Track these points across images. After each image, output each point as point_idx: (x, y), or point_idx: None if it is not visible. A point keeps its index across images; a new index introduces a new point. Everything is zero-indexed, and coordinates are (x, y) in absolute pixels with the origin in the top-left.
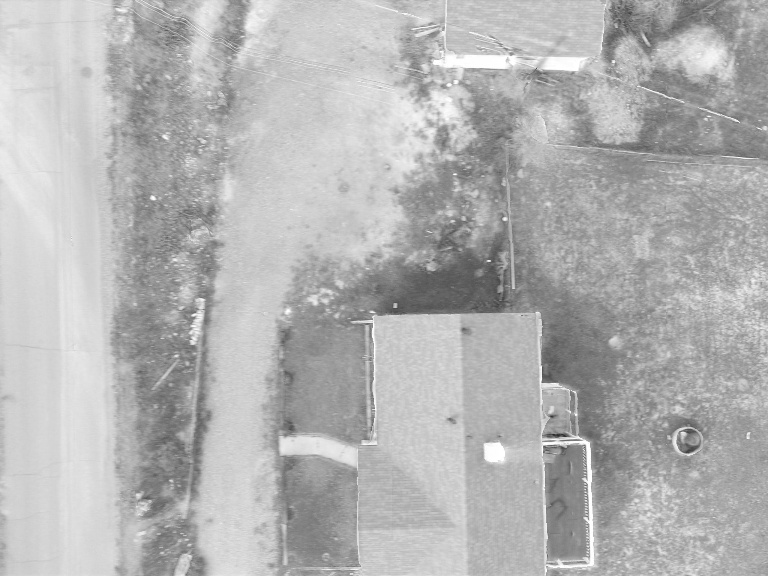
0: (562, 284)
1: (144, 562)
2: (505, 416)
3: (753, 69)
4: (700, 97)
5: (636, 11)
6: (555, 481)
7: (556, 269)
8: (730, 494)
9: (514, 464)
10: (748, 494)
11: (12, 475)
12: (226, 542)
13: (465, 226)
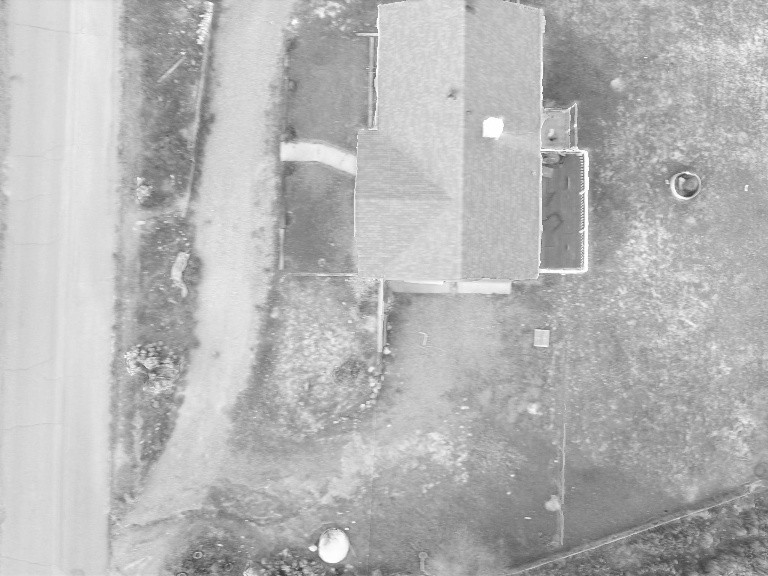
0: (566, 22)
1: (142, 252)
2: (505, 101)
3: None
4: None
5: None
6: (552, 195)
7: (561, 7)
8: (726, 244)
9: (512, 150)
10: (744, 246)
11: (16, 156)
12: (224, 244)
13: None
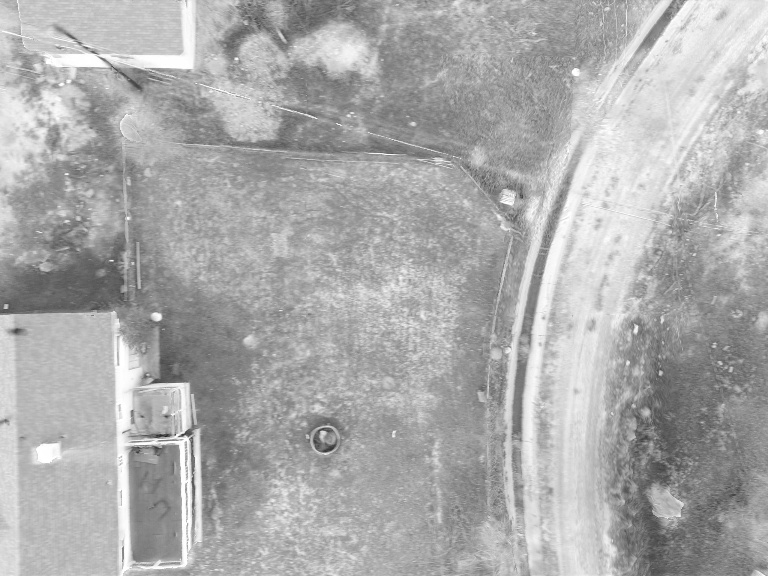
0: (194, 283)
1: None
2: (70, 417)
3: (399, 65)
4: (343, 94)
5: (270, 8)
6: (158, 482)
7: (187, 268)
8: (374, 493)
9: (81, 465)
10: (394, 493)
11: None
12: None
13: (81, 226)
